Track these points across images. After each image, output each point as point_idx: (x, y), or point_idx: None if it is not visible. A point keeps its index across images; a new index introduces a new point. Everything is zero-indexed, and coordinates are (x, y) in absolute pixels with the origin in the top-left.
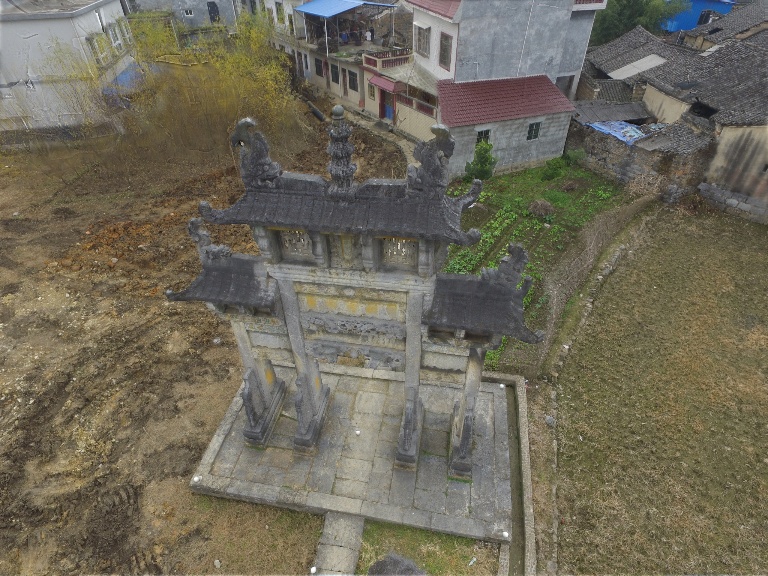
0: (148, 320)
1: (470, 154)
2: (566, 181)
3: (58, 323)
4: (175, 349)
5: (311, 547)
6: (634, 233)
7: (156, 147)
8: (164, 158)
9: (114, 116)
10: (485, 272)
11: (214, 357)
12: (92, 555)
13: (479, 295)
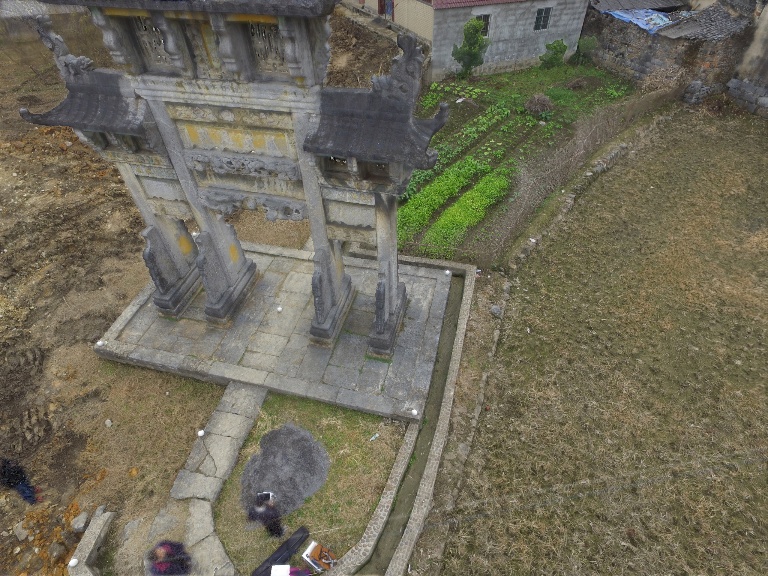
0: (90, 199)
1: None
2: (573, 77)
3: (1, 200)
4: (113, 228)
5: (208, 414)
6: (641, 132)
7: None
8: None
9: None
10: (375, 80)
11: None
12: None
13: (371, 113)
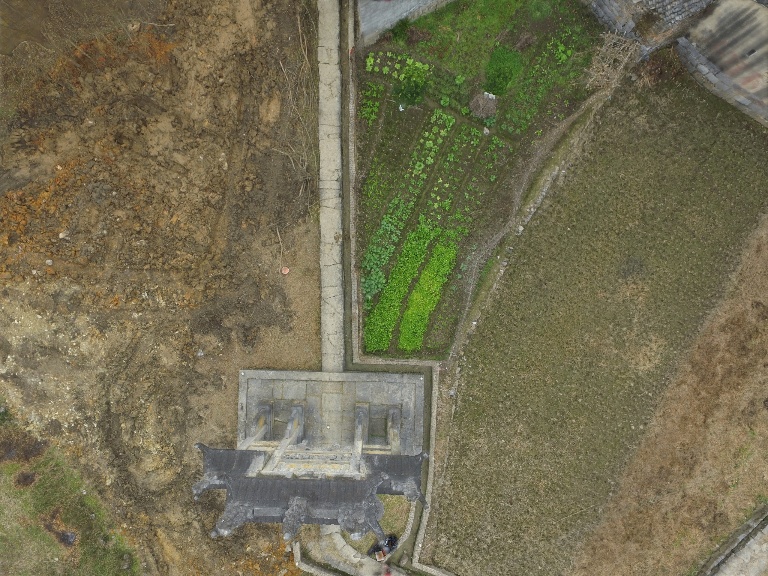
0: (131, 338)
1: (401, 3)
2: (523, 35)
3: (56, 350)
4: (170, 362)
5: None
6: (575, 139)
7: None
8: None
9: None
10: None
11: (205, 369)
12: (202, 510)
13: None
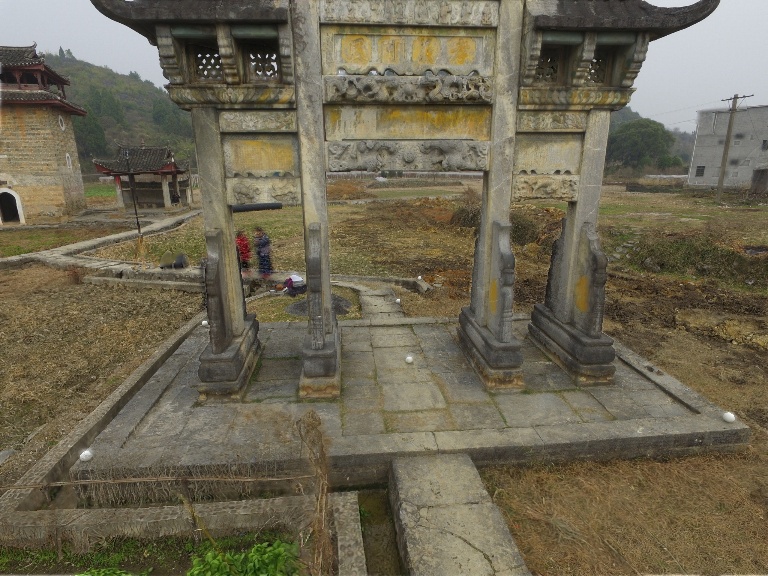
0: None
1: None
2: None
3: None
4: None
5: None
6: None
7: None
8: None
9: None
10: None
11: None
12: None
13: None
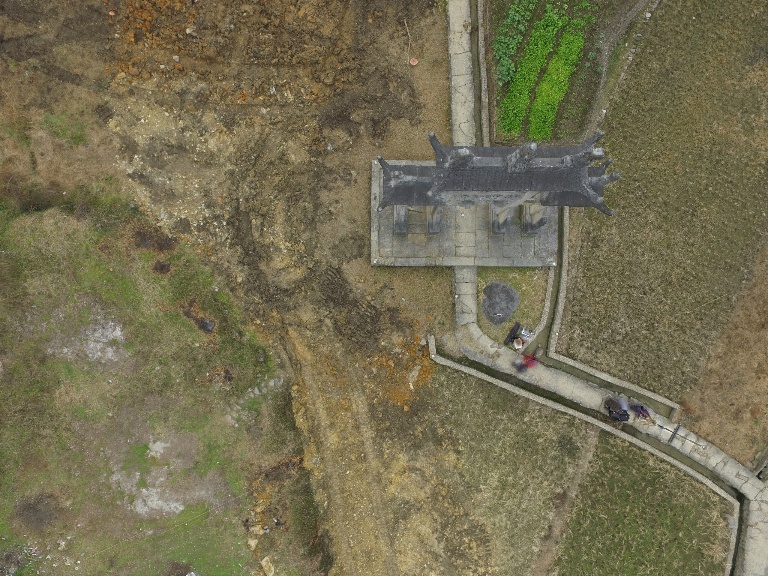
0: (260, 134)
1: None
2: None
3: (184, 148)
4: (298, 159)
5: (449, 283)
6: None
7: None
8: None
9: None
10: (590, 181)
11: (335, 164)
12: (335, 306)
13: None
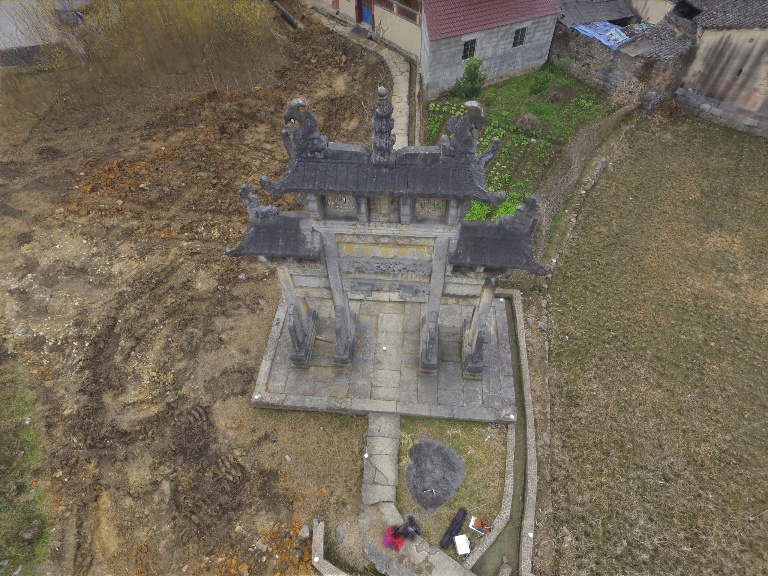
0: (172, 261)
1: (457, 66)
2: (551, 91)
3: (85, 270)
4: (204, 287)
5: (360, 439)
6: (614, 144)
7: (129, 73)
8: (135, 82)
9: (81, 41)
10: (502, 219)
11: (243, 292)
12: (184, 461)
13: (496, 237)
